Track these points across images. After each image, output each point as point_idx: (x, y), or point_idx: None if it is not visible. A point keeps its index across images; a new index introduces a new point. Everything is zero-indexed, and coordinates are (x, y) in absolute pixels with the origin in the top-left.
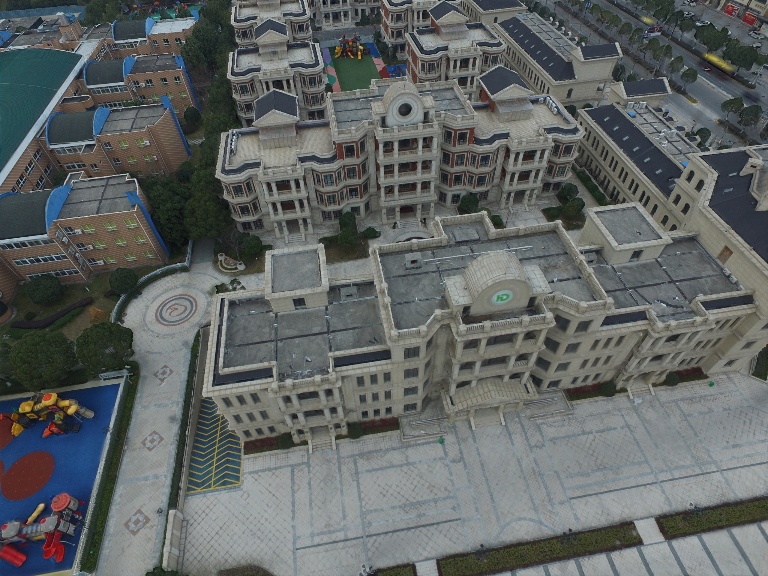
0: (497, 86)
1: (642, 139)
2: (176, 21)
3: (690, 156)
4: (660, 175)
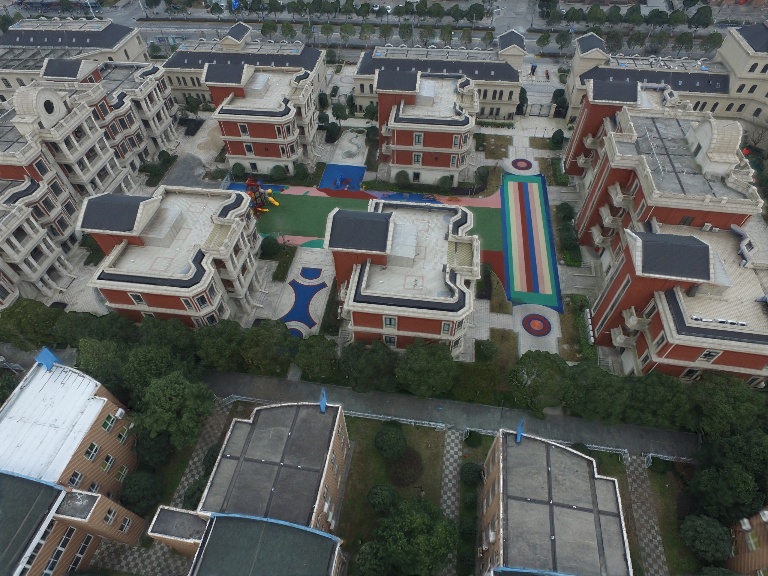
0: (625, 93)
1: (657, 74)
2: (8, 413)
3: (755, 55)
4: (702, 85)
